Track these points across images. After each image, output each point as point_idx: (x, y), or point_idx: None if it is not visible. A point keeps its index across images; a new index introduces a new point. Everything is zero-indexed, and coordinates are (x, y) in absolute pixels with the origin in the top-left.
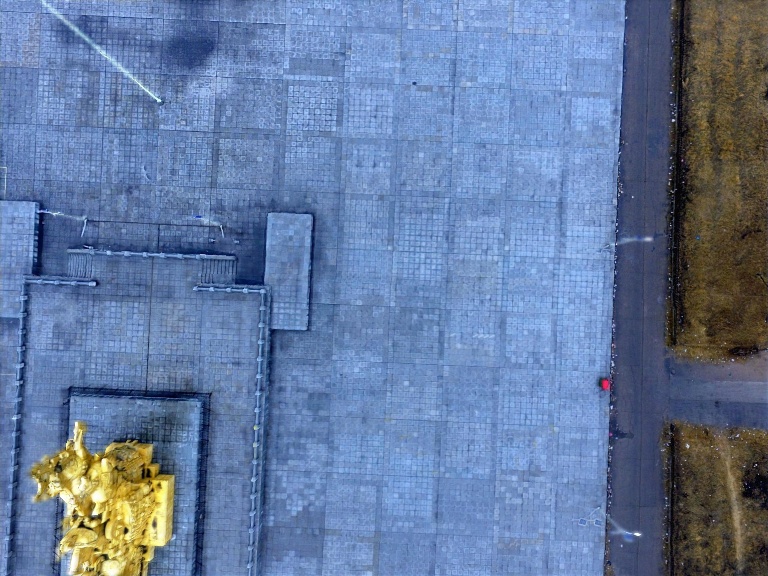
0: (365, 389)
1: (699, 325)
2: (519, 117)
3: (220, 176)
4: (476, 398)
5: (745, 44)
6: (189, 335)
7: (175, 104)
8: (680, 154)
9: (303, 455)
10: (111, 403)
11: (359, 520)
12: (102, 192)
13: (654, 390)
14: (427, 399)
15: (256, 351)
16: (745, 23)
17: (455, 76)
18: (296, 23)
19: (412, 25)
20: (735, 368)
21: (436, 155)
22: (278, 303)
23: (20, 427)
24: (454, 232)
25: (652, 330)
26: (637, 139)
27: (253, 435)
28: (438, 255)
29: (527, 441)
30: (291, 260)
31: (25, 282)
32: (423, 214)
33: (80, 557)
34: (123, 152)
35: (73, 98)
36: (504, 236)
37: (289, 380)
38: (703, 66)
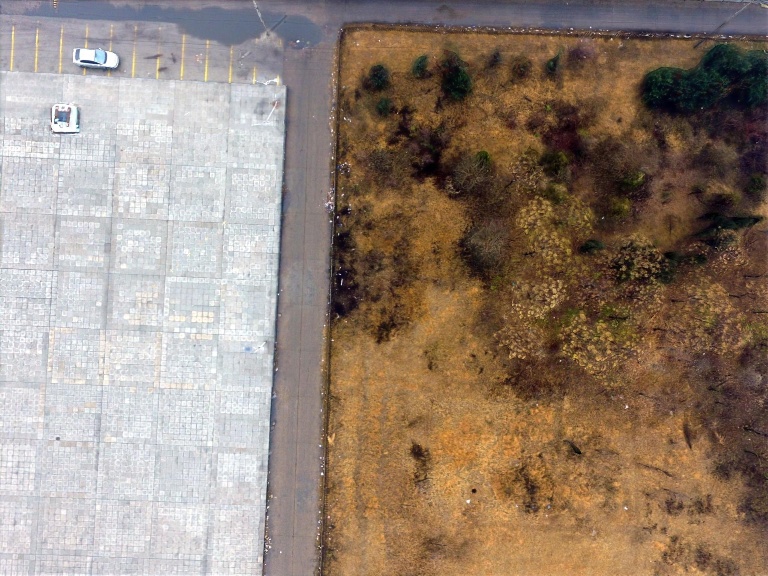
0: None
1: None
2: (164, 473)
3: None
4: None
5: (391, 400)
6: None
7: None
8: (326, 511)
9: None
10: None
11: None
12: None
13: None
14: None
15: None
16: (391, 379)
17: (100, 431)
18: None
19: (56, 379)
20: None
21: (79, 512)
22: None
23: None
24: None
25: None
26: (286, 493)
27: None
28: None
29: None
30: None
31: None
32: (64, 573)
33: None
34: None
35: None
36: None
37: None
38: (349, 422)
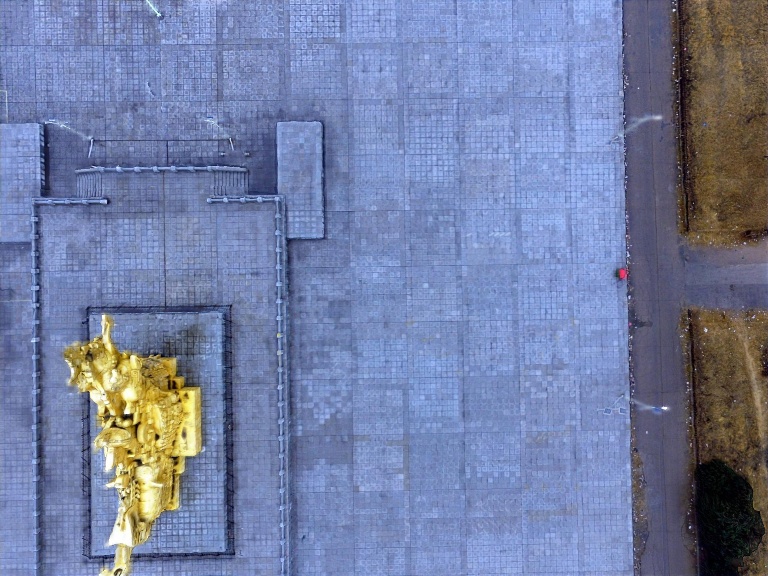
0: (385, 294)
1: (710, 210)
2: (522, 14)
3: (226, 89)
4: (496, 296)
5: None
6: (205, 248)
7: (175, 18)
8: (683, 42)
9: (327, 363)
10: (131, 319)
11: (387, 424)
12: (107, 111)
13: (670, 278)
14: (447, 300)
15: (274, 260)
16: None
17: None
18: None
19: None
20: (747, 251)
21: (442, 56)
22: (293, 212)
23: (39, 351)
24: (464, 132)
25: (665, 219)
26: (639, 30)
27: (276, 344)
28: (450, 156)
29: (548, 335)
30: (303, 168)
31: (35, 203)
32: (432, 116)
33: (114, 456)
34: (125, 69)
35: (71, 17)
36: (514, 133)
37: (308, 289)
38: None
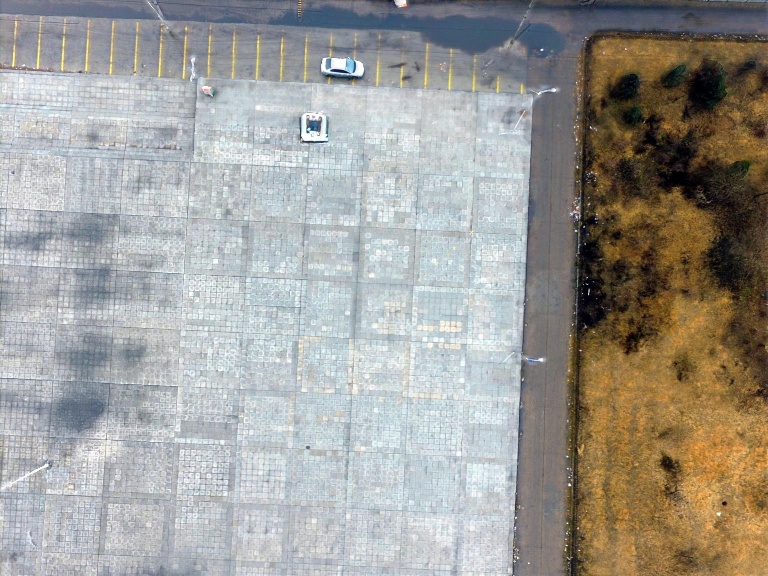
0: None
1: None
2: (414, 482)
3: (108, 542)
4: None
5: (640, 411)
6: None
7: (63, 468)
8: (576, 522)
9: None
10: None
11: None
12: None
13: None
14: None
15: None
16: (640, 390)
17: (349, 440)
18: (188, 385)
19: (306, 388)
20: None
21: (329, 521)
22: None
23: None
24: None
25: None
26: (533, 503)
27: None
28: None
29: None
30: None
31: None
32: None
33: None
34: (8, 517)
35: None
36: None
37: None
38: (598, 433)
